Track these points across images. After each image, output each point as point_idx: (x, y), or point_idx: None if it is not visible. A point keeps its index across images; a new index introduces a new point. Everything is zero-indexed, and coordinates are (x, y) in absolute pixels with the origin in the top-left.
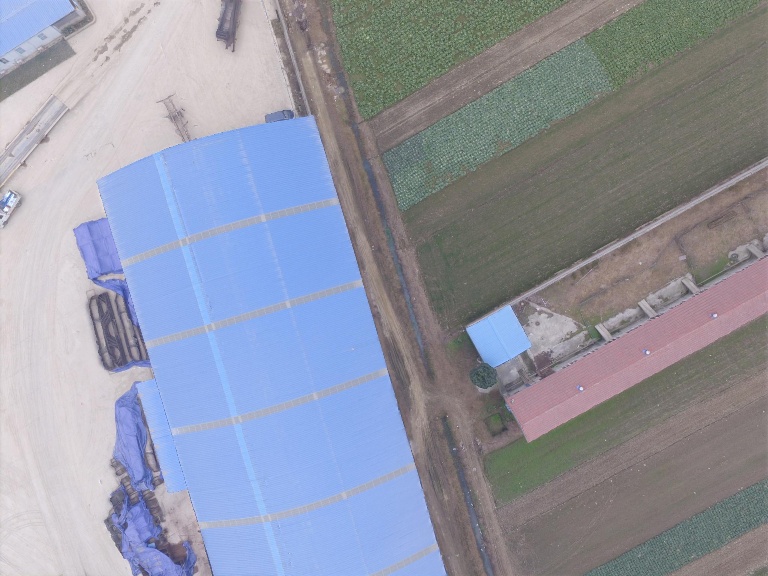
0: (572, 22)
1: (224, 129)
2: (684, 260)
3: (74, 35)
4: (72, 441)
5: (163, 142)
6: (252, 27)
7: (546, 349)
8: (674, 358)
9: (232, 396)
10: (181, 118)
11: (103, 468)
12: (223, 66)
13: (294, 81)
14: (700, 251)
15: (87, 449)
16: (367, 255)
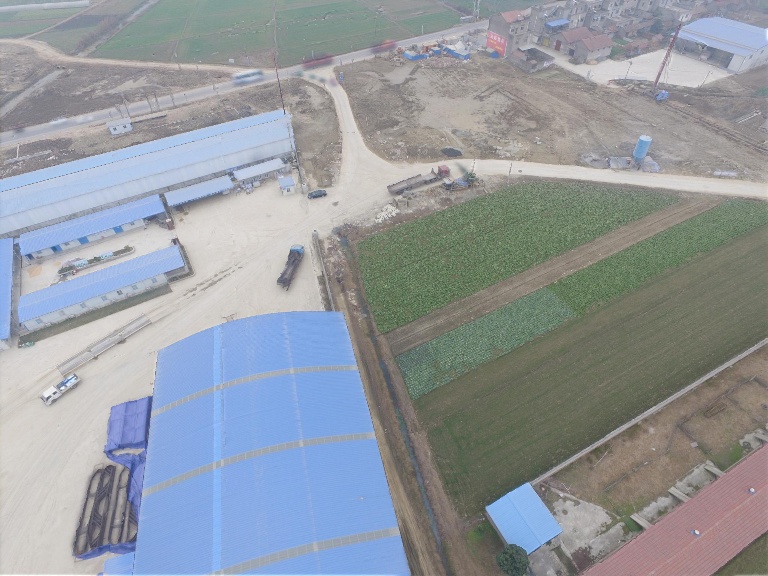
0: (534, 279)
1: None
2: (697, 447)
3: (176, 282)
4: None
5: None
6: (303, 280)
7: (583, 544)
8: (733, 546)
9: (221, 543)
10: None
11: None
12: (277, 300)
13: (329, 309)
14: (709, 438)
15: None
16: (380, 437)
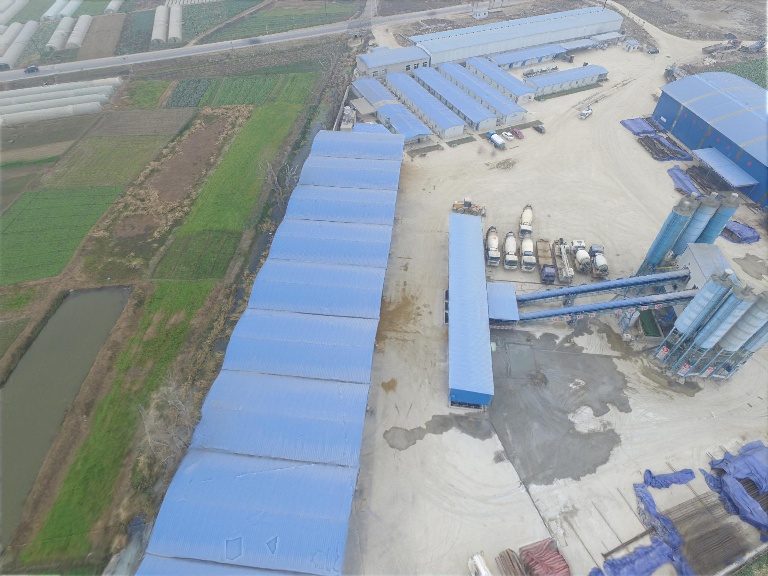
0: None
1: None
2: None
3: None
4: None
5: None
6: None
7: None
8: None
9: None
10: None
11: (671, 192)
12: None
13: None
14: None
15: (657, 185)
16: None
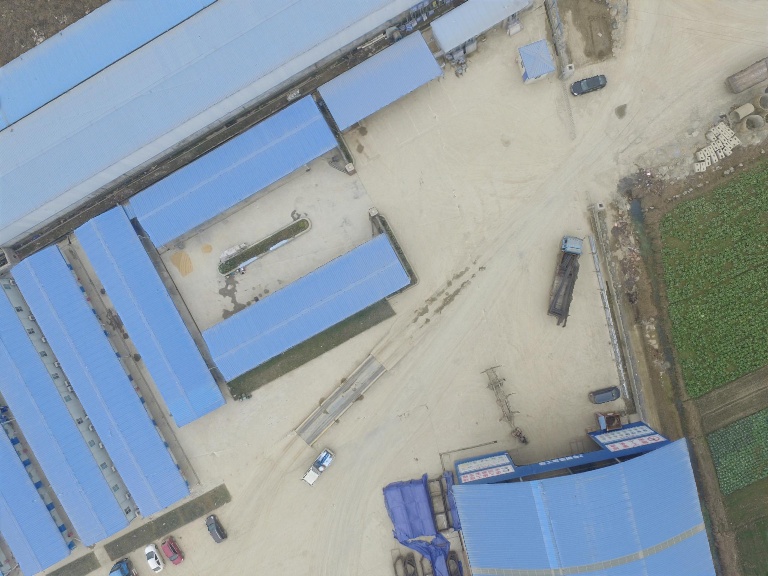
0: None
1: (543, 399)
2: None
3: (395, 296)
4: None
5: (479, 408)
6: (580, 298)
7: None
8: None
9: None
10: (502, 388)
11: None
12: (546, 335)
13: (620, 355)
14: None
15: None
16: None
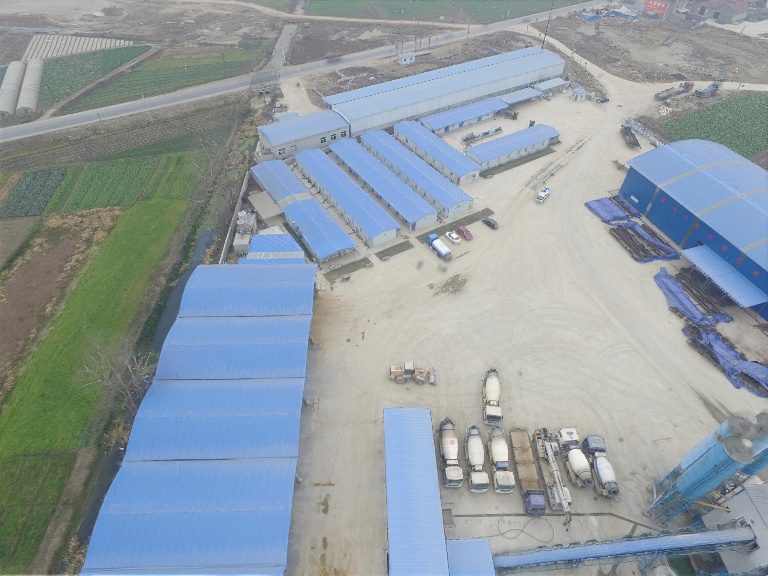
0: None
1: None
2: None
3: (553, 146)
4: (633, 299)
5: (618, 176)
6: (641, 145)
7: None
8: None
9: None
10: None
11: (665, 314)
12: (634, 155)
13: None
14: None
15: (647, 303)
16: None
